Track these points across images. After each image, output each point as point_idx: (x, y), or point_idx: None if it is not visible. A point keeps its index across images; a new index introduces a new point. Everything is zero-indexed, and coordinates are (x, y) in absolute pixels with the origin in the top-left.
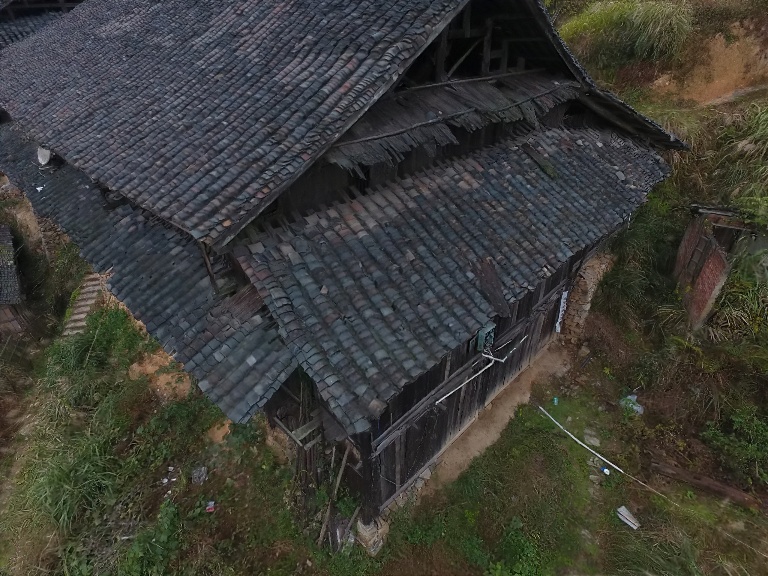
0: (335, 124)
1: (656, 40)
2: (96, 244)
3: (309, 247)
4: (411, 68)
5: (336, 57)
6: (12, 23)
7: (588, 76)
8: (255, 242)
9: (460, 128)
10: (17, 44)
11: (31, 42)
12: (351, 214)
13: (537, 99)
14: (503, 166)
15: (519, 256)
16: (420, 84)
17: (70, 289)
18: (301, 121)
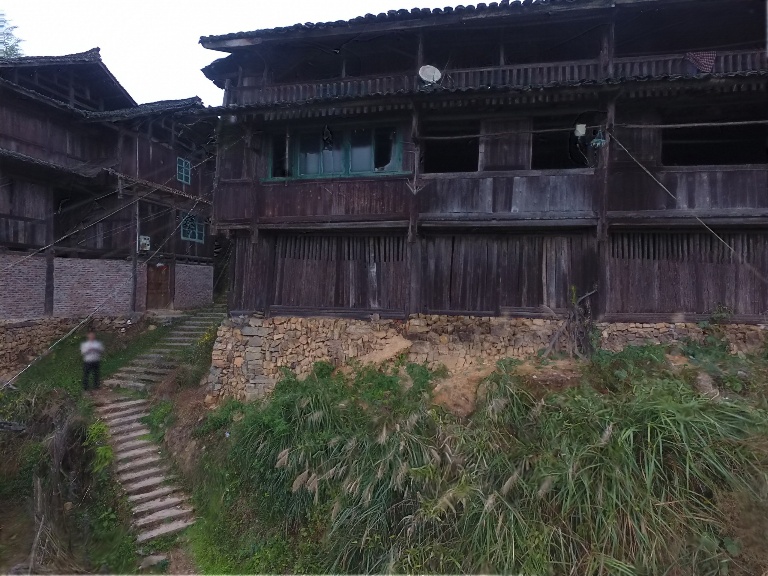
0: None
1: None
2: None
3: None
4: None
5: None
6: None
7: None
8: None
9: None
10: None
11: None
12: None
13: None
14: None
15: None
16: None
17: (80, 425)
18: None
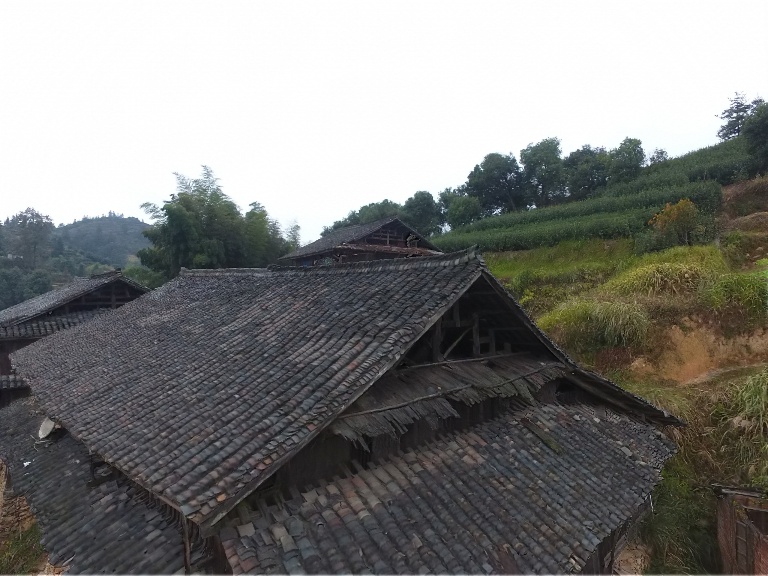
0: (342, 397)
1: (621, 330)
2: (64, 527)
3: (304, 529)
4: (411, 350)
5: (345, 341)
6: (65, 316)
7: (570, 358)
8: (246, 522)
9: (459, 402)
10: (63, 331)
11: (77, 330)
12: (352, 490)
13: (528, 377)
14: (506, 440)
15: (540, 543)
16: (419, 363)
17: None
18: (310, 394)
